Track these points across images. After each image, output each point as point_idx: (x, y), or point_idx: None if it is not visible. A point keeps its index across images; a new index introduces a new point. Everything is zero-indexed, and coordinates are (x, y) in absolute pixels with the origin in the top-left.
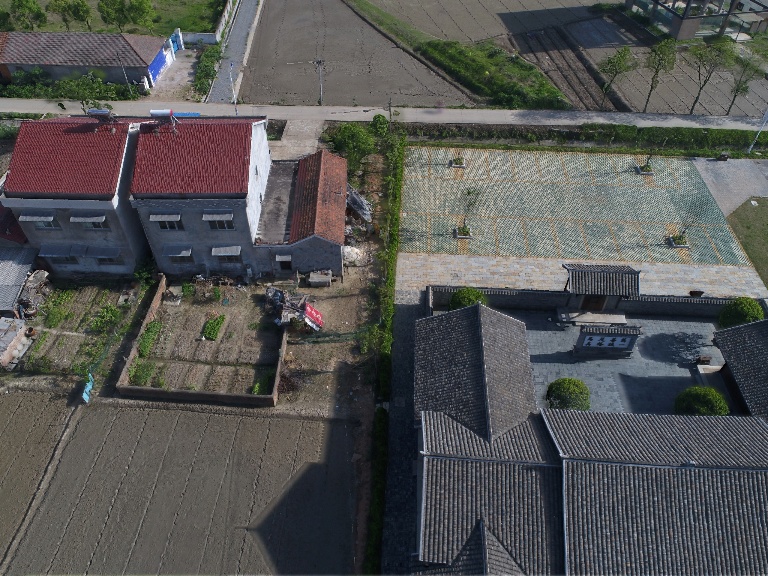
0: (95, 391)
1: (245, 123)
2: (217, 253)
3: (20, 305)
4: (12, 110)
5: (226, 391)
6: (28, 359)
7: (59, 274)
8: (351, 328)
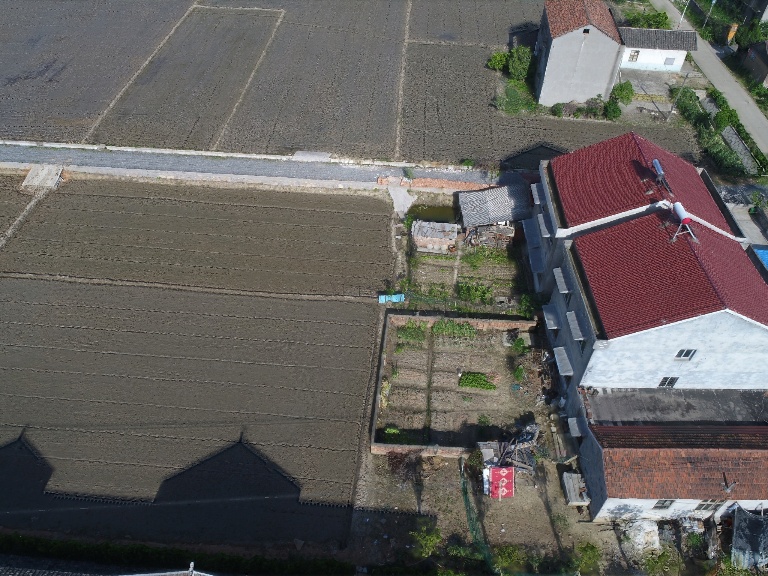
0: (391, 305)
1: (722, 300)
2: (557, 352)
3: (475, 231)
4: (767, 153)
5: (393, 405)
6: (425, 256)
7: (524, 247)
8: (495, 536)
